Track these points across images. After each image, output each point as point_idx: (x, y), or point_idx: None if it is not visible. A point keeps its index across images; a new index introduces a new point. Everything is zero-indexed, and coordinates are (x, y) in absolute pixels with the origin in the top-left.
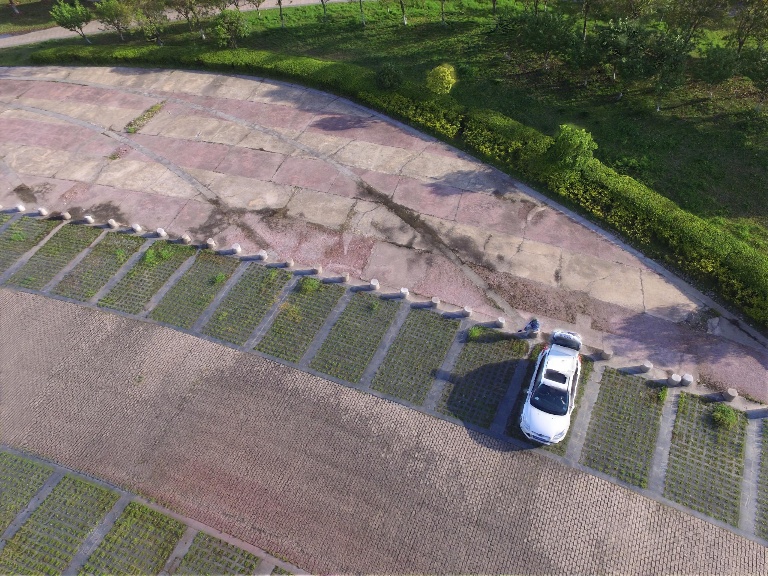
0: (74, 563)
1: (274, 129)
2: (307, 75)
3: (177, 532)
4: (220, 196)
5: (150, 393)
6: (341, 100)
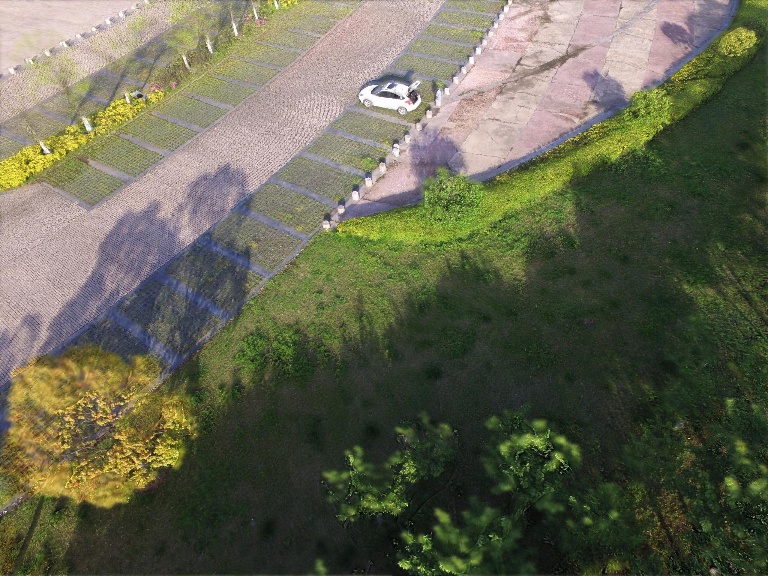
0: (332, 2)
1: (653, 9)
2: (746, 7)
3: (339, 18)
4: (559, 1)
5: (406, 5)
6: (719, 32)
